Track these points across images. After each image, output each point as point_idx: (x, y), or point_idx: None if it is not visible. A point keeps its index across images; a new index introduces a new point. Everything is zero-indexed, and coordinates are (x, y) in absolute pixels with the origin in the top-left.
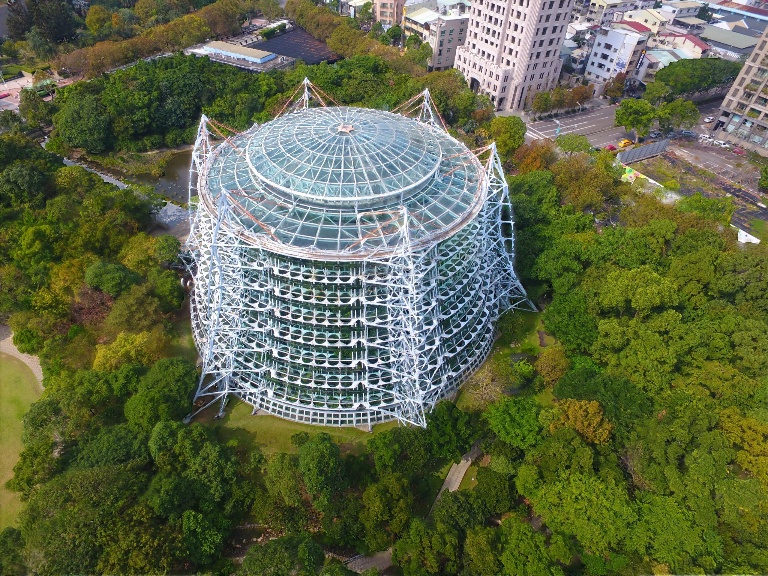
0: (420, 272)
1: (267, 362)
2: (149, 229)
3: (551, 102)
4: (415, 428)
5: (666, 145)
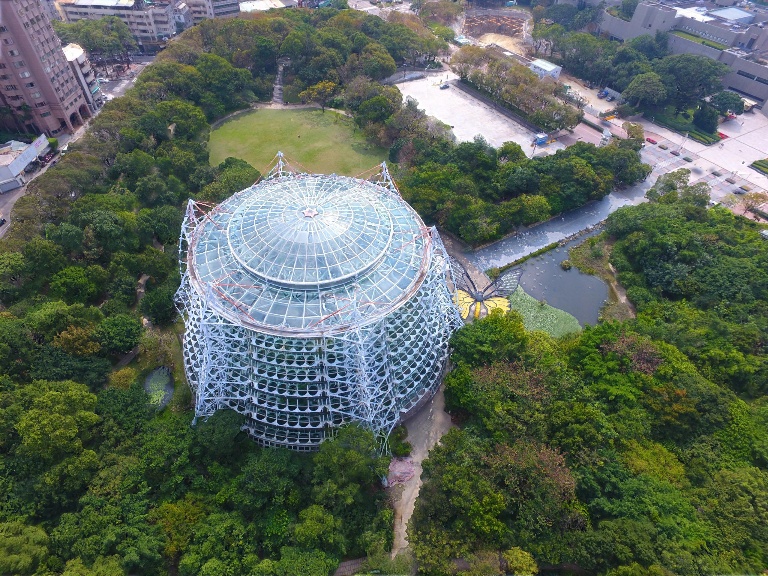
0: None
1: None
2: (463, 242)
3: None
4: None
5: None
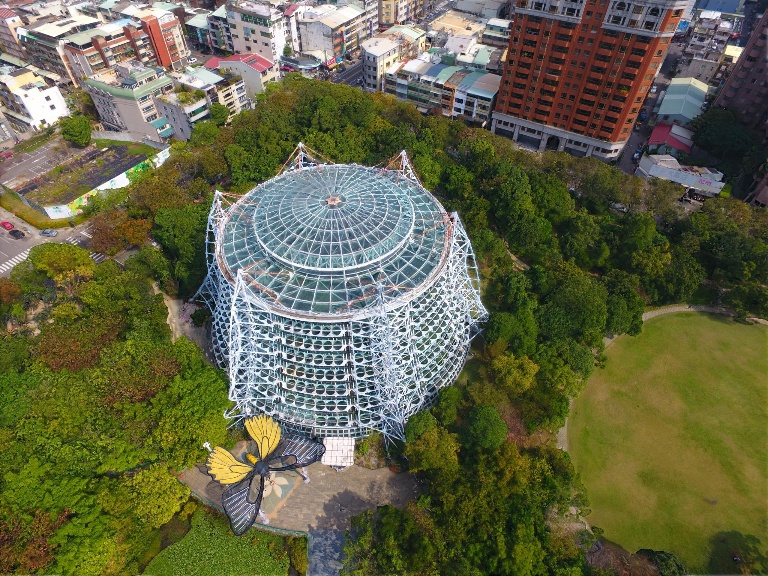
0: None
1: None
2: None
3: None
4: None
5: (4, 189)
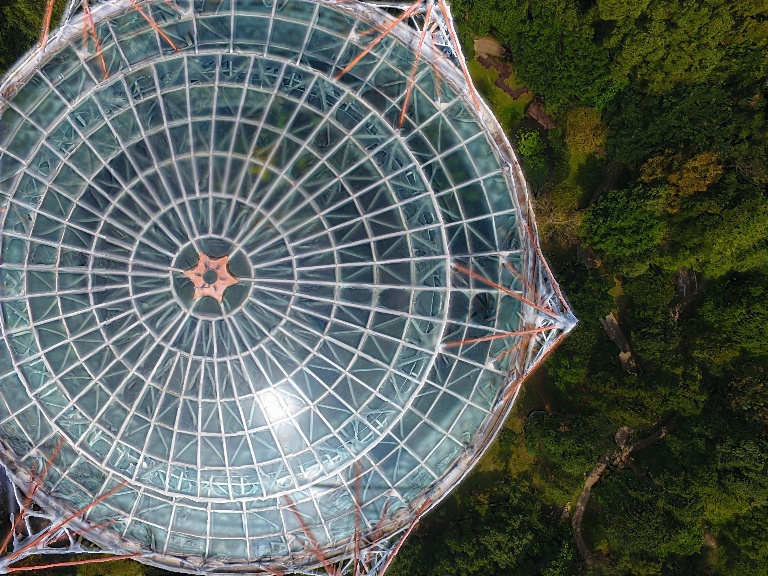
0: None
1: None
2: None
3: None
4: None
5: None
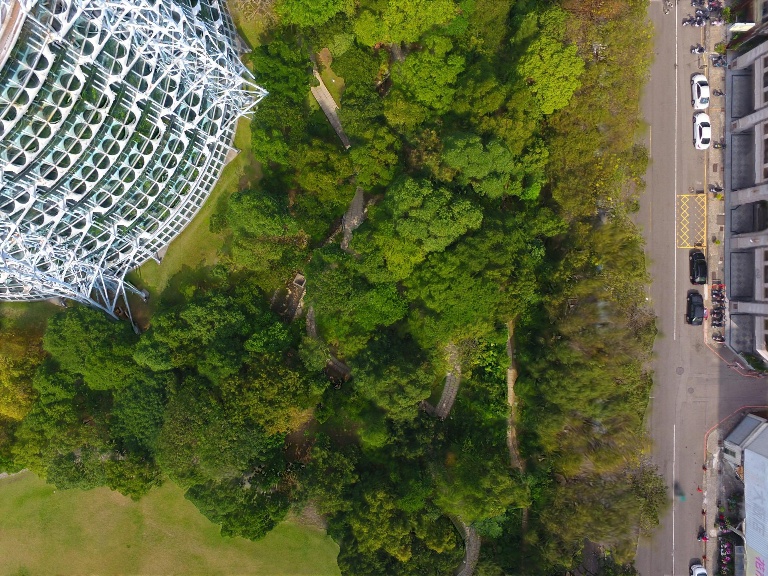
0: None
1: (106, 224)
2: None
3: None
4: (264, 104)
5: None
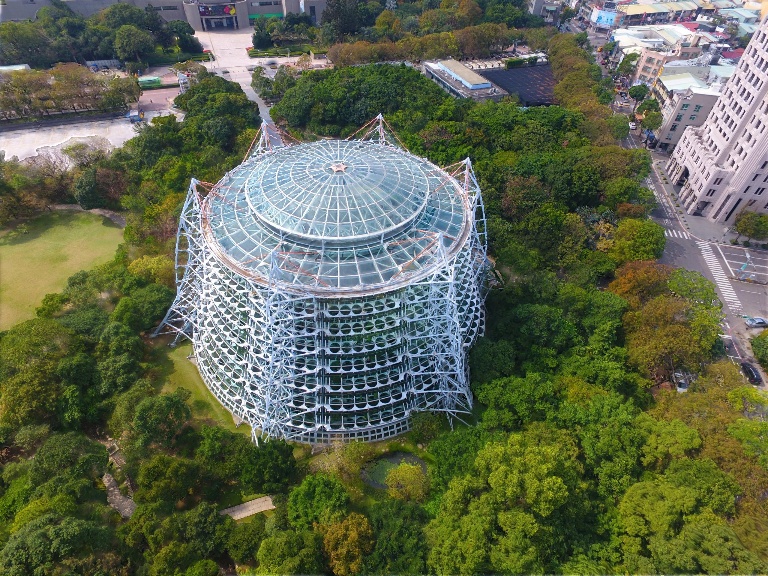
0: (291, 314)
1: None
2: None
3: (767, 230)
4: (249, 444)
5: None
